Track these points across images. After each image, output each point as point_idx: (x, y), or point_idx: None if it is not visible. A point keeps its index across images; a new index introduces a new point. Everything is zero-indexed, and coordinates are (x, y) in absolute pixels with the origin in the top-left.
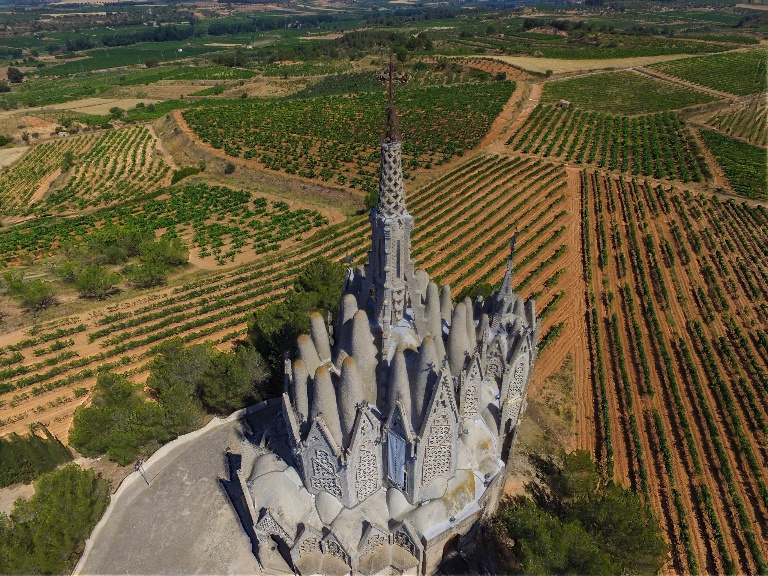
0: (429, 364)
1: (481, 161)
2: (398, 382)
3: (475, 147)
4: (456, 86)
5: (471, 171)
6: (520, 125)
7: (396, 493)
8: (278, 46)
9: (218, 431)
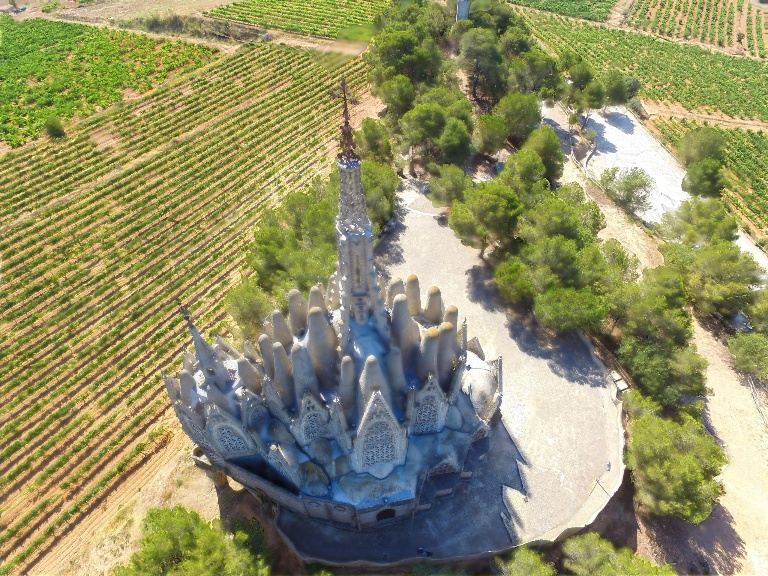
0: None
1: None
2: None
3: None
4: None
5: None
6: None
7: None
8: (470, 14)
9: (543, 532)
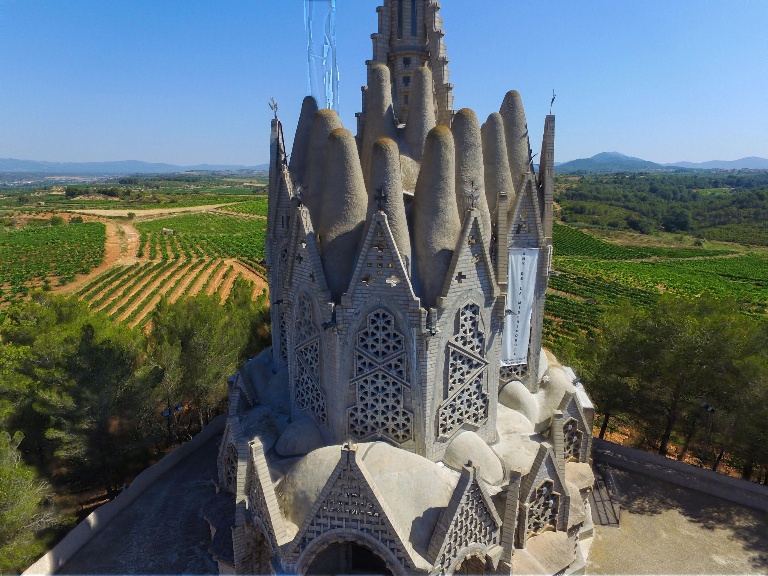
0: (525, 125)
1: (120, 271)
2: (505, 160)
3: (100, 265)
4: (21, 230)
5: (116, 279)
6: (137, 246)
7: (518, 384)
8: None
9: None
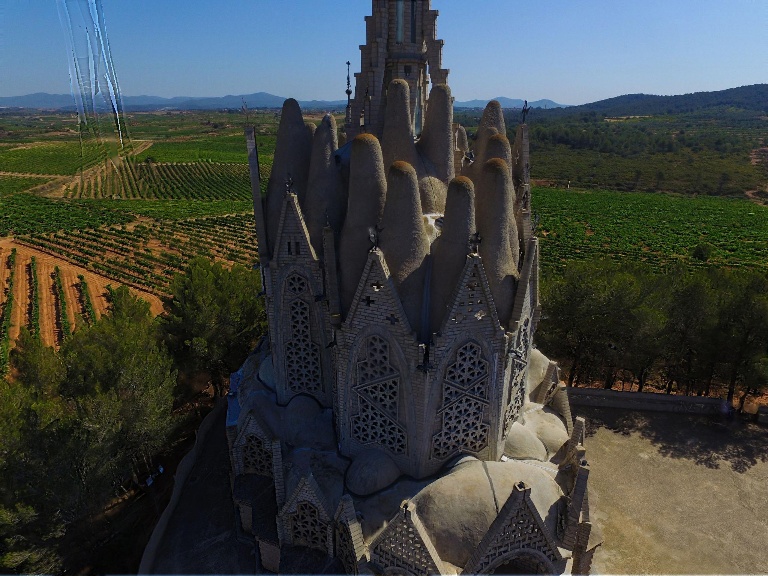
0: None
1: None
2: None
3: None
4: None
5: None
6: None
7: None
8: None
9: None
